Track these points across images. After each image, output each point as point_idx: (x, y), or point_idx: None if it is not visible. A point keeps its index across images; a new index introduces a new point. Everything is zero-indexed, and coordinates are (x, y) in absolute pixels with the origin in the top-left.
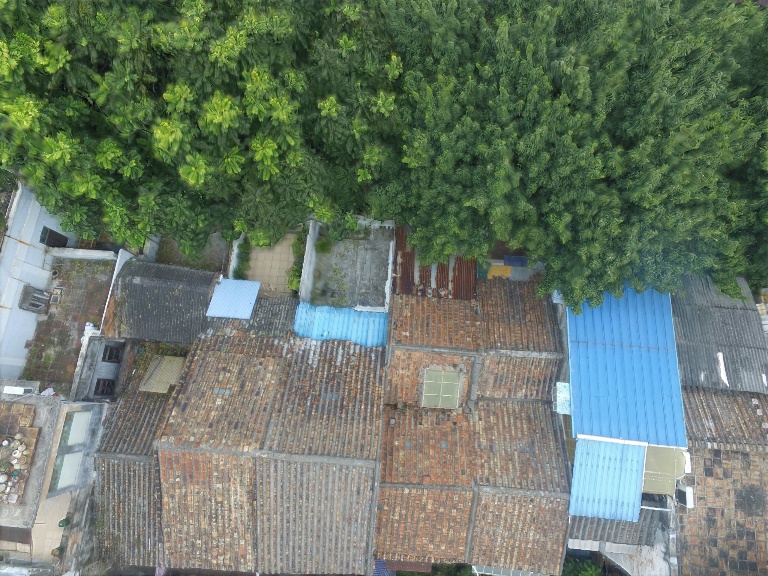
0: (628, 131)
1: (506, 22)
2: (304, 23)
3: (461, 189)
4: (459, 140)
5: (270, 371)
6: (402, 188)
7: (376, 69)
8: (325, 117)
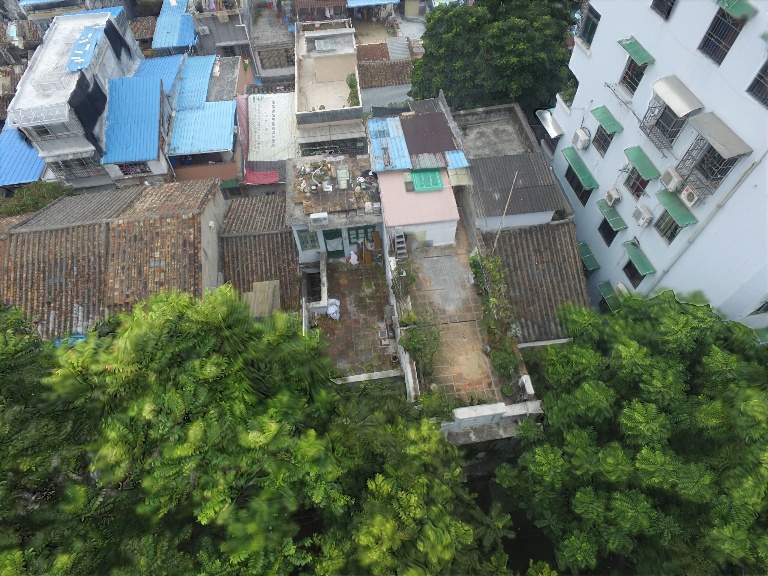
0: None
1: None
2: None
3: None
4: None
5: (116, 290)
6: None
7: None
8: None
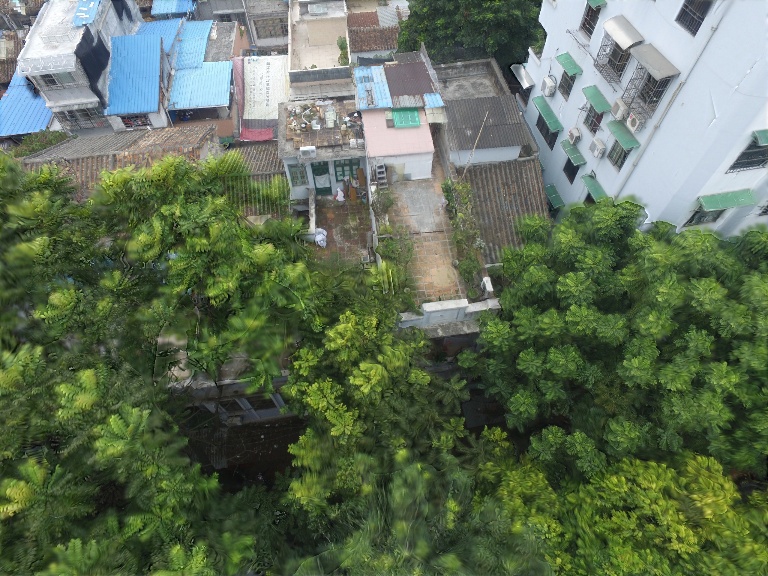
0: None
1: None
2: None
3: None
4: None
5: None
6: None
7: None
8: None
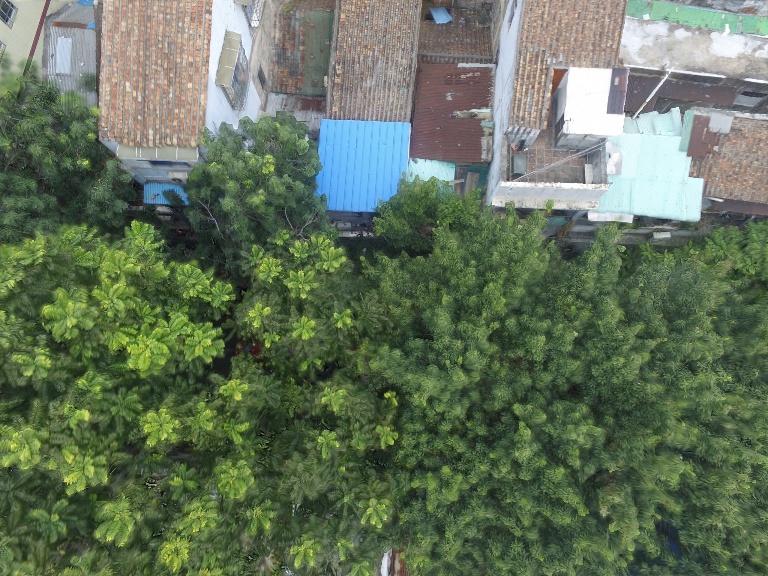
0: (681, 536)
1: (528, 432)
2: (275, 383)
3: (472, 566)
4: (469, 525)
5: None
6: (399, 535)
7: (365, 437)
8: (300, 565)
